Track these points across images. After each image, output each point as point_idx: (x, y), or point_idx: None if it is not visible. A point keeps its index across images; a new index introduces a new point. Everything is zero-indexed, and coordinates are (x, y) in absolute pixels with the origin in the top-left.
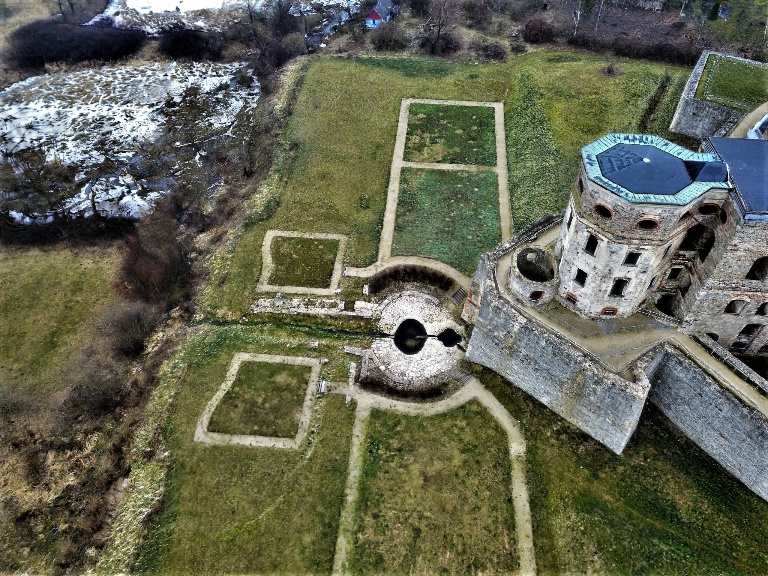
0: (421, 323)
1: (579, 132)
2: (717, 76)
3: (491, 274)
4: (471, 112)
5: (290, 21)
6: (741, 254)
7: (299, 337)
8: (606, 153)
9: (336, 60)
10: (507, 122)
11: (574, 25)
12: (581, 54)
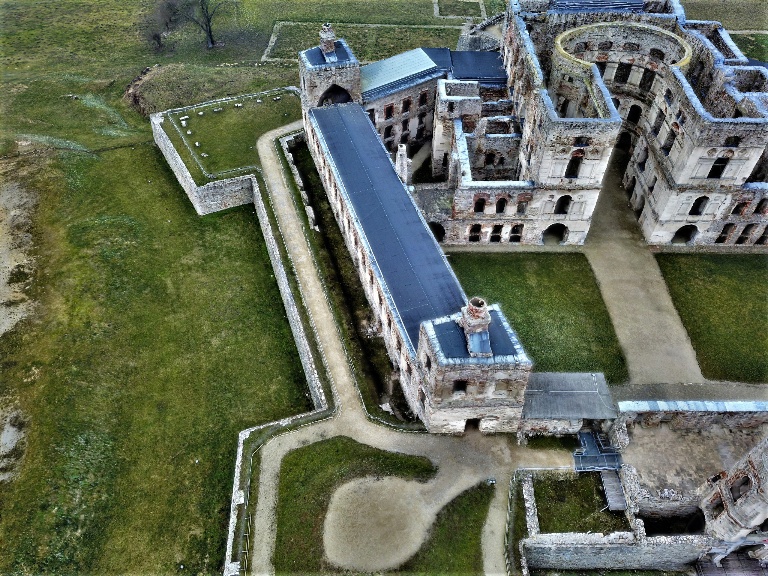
0: None
1: None
2: None
3: None
4: None
5: None
6: None
7: None
8: None
9: None
10: None
11: None
12: None
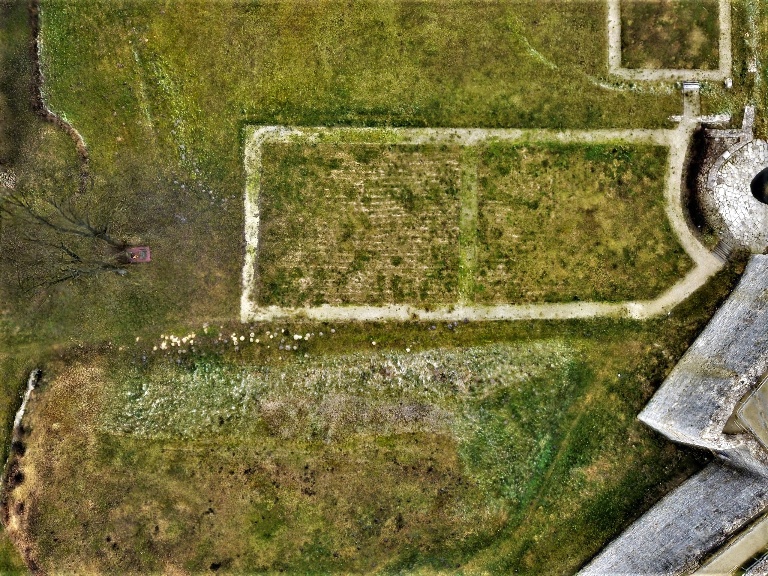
0: None
1: None
2: None
3: None
4: None
5: None
6: None
7: (763, 47)
8: None
9: None
10: None
11: None
12: None
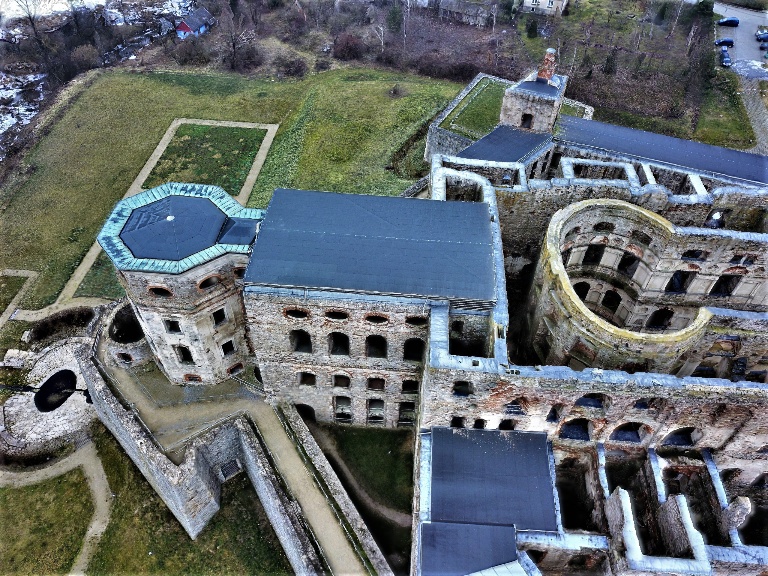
0: (75, 375)
1: (326, 160)
2: (476, 102)
3: (96, 330)
4: (240, 134)
5: (89, 32)
6: (268, 327)
7: None
8: (146, 207)
9: (128, 75)
10: (273, 146)
11: (386, 41)
12: (384, 72)
